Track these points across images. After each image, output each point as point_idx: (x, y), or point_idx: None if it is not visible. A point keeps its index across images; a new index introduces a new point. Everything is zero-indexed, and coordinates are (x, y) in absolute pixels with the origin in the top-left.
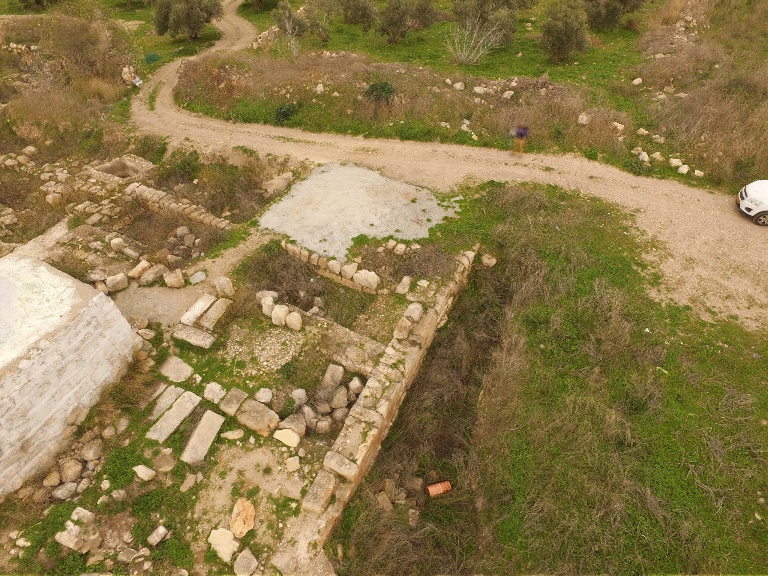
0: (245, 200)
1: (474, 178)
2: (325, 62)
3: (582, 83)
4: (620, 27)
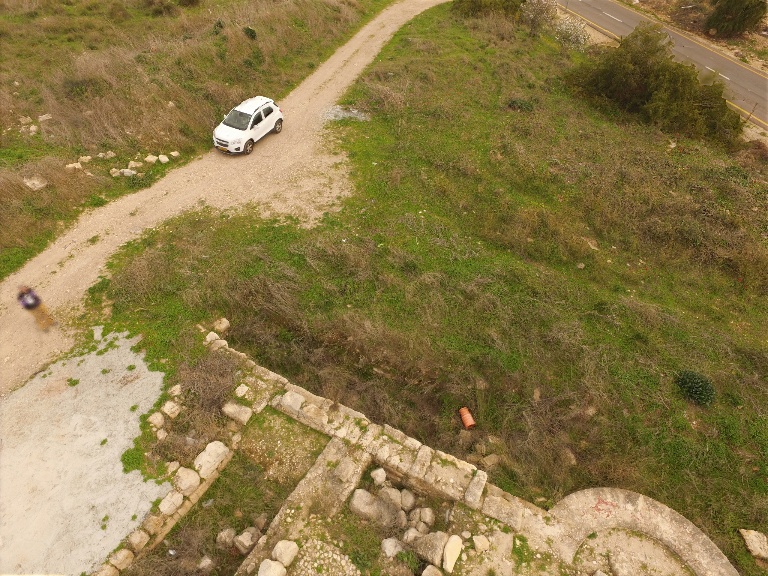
0: None
1: (63, 308)
2: None
3: None
4: None
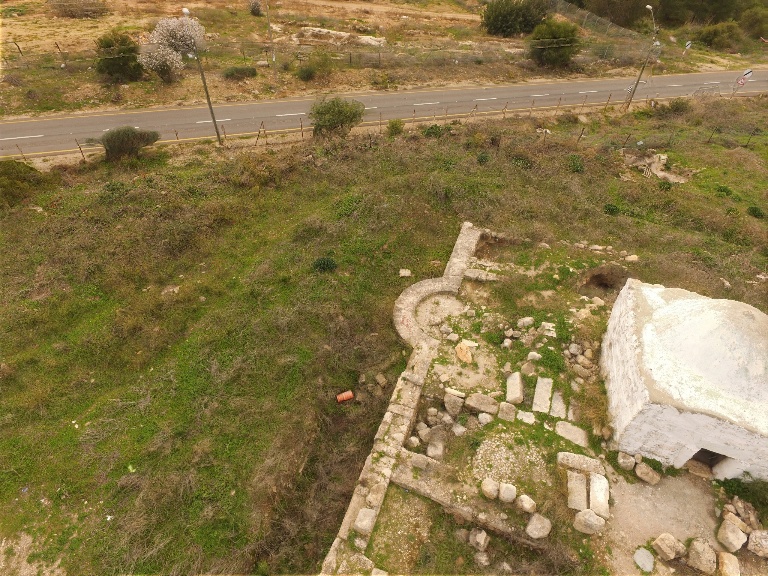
0: None
1: None
2: None
3: None
4: None
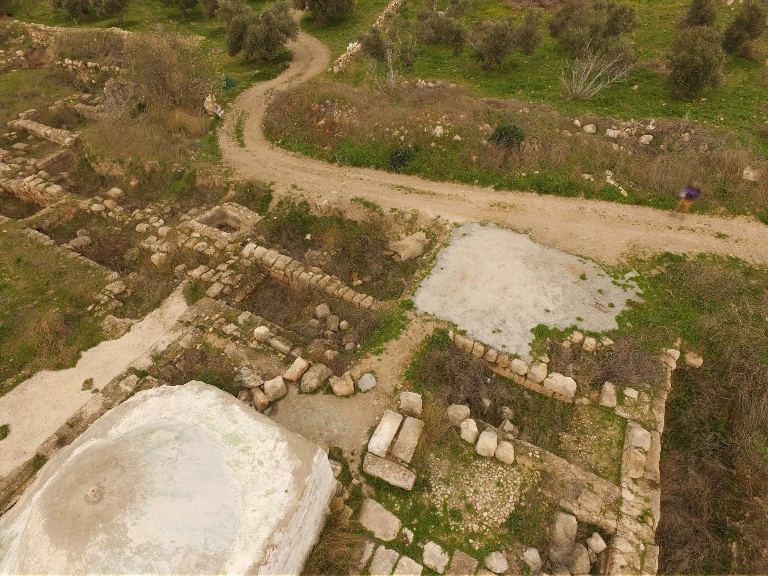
0: (384, 270)
1: (640, 247)
2: (427, 94)
3: (721, 125)
4: (733, 54)
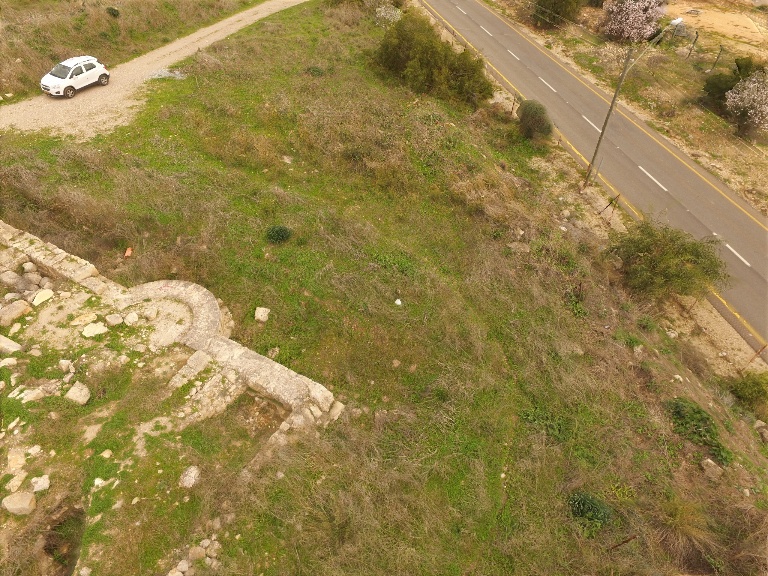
0: None
1: None
2: None
3: None
4: None
